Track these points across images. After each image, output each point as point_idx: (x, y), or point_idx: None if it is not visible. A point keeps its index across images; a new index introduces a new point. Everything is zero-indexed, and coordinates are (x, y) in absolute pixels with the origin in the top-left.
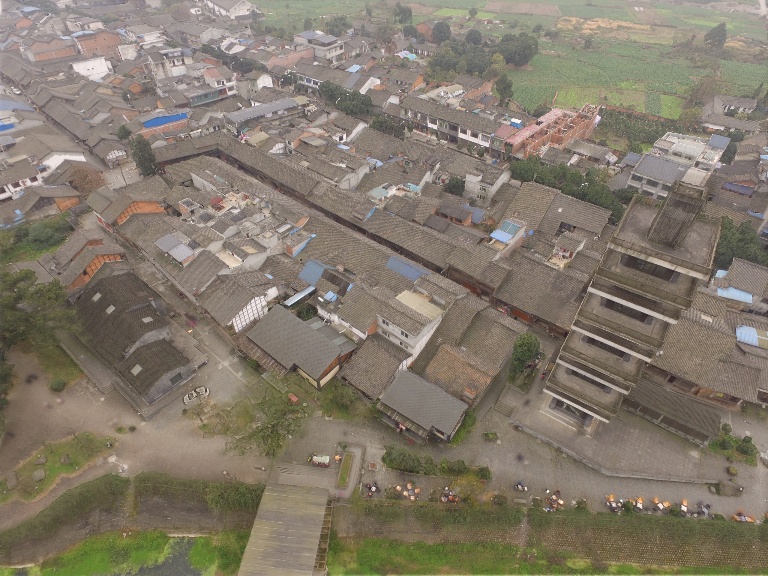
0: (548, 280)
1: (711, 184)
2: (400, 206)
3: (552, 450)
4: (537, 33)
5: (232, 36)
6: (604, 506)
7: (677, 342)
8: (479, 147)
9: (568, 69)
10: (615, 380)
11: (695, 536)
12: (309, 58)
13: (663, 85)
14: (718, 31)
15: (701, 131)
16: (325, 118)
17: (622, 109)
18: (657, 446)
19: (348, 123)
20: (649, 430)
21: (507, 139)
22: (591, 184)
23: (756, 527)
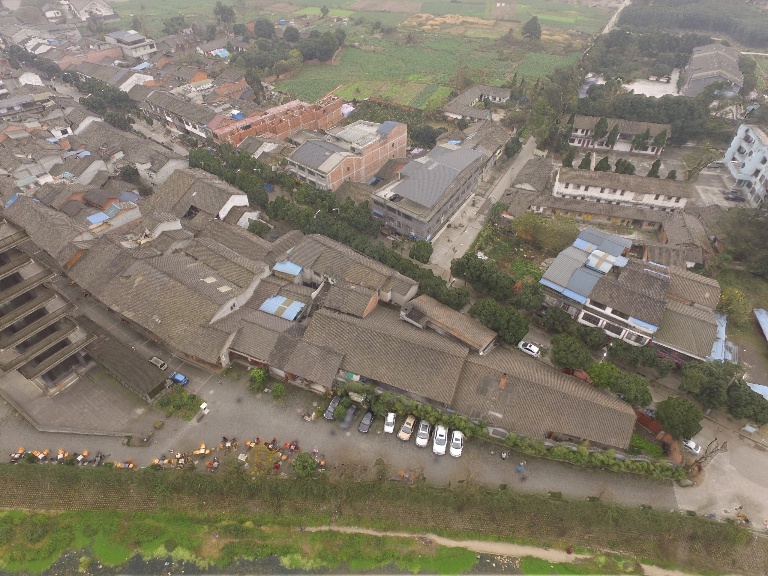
0: (111, 257)
1: (385, 168)
2: (45, 193)
3: (10, 410)
4: (375, 30)
5: (50, 37)
6: (10, 457)
7: (177, 310)
8: (203, 138)
9: (372, 63)
10: (2, 340)
11: (80, 482)
12: (117, 57)
13: (449, 77)
14: (531, 24)
15: (443, 120)
16: (60, 113)
17: (382, 100)
18: (108, 404)
19: (77, 117)
20: (114, 391)
21: (215, 130)
22: (262, 170)
23: (129, 472)
